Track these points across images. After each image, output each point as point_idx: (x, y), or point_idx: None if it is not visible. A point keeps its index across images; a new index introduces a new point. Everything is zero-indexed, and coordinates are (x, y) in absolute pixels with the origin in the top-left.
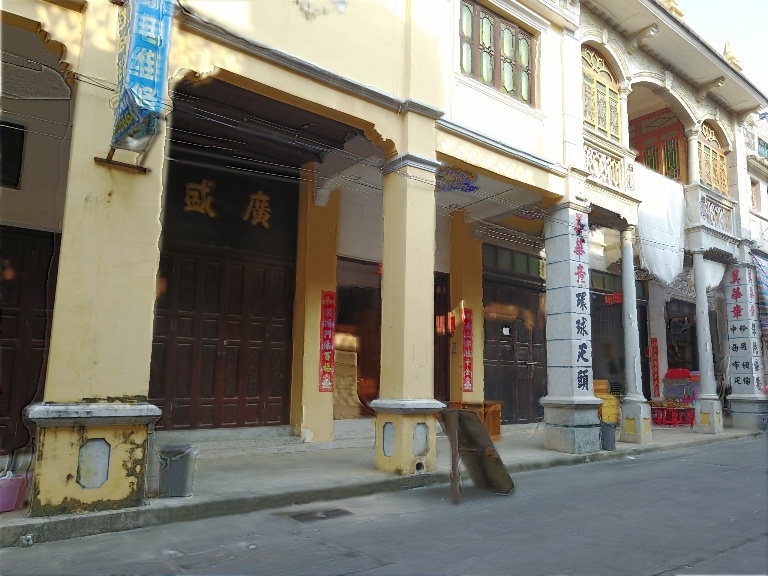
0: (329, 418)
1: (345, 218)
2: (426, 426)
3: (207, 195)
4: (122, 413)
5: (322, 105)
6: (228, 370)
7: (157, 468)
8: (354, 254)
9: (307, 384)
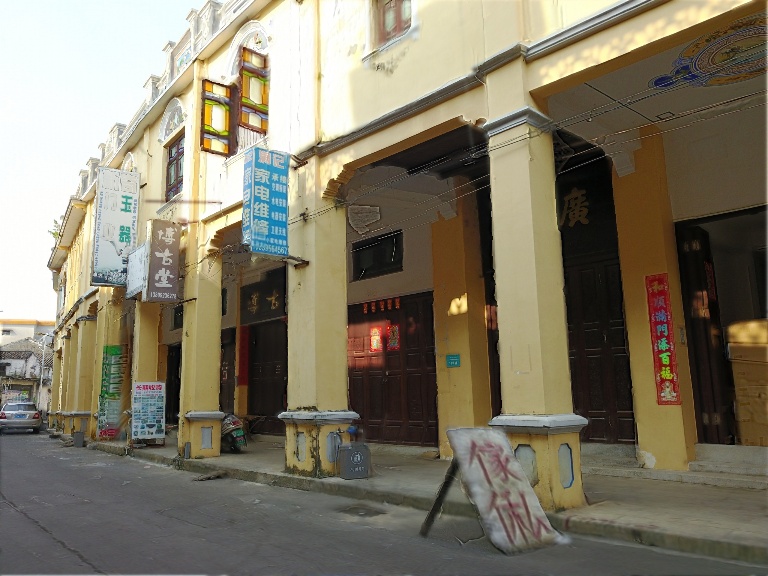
0: (678, 440)
1: (695, 165)
2: (531, 449)
3: None
4: (301, 417)
5: (414, 135)
6: None
7: (335, 456)
8: (722, 207)
9: (639, 395)
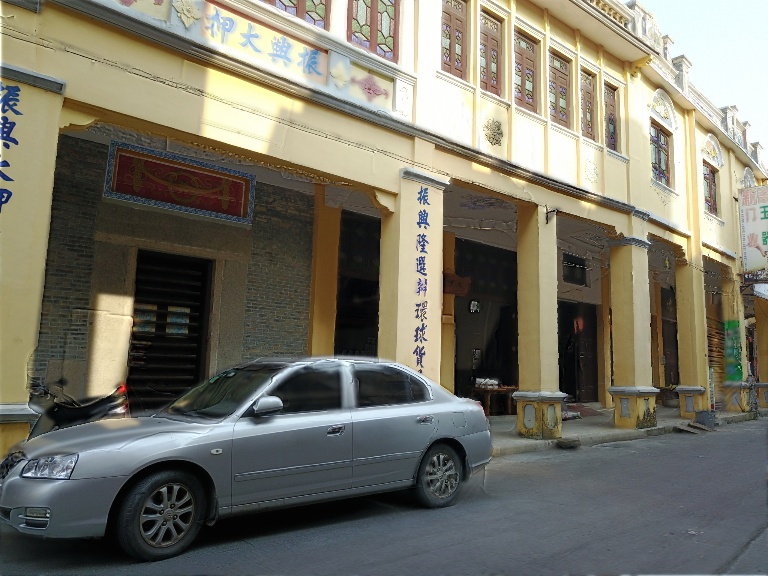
0: None
1: None
2: None
3: None
4: None
5: None
6: None
7: None
8: None
9: None
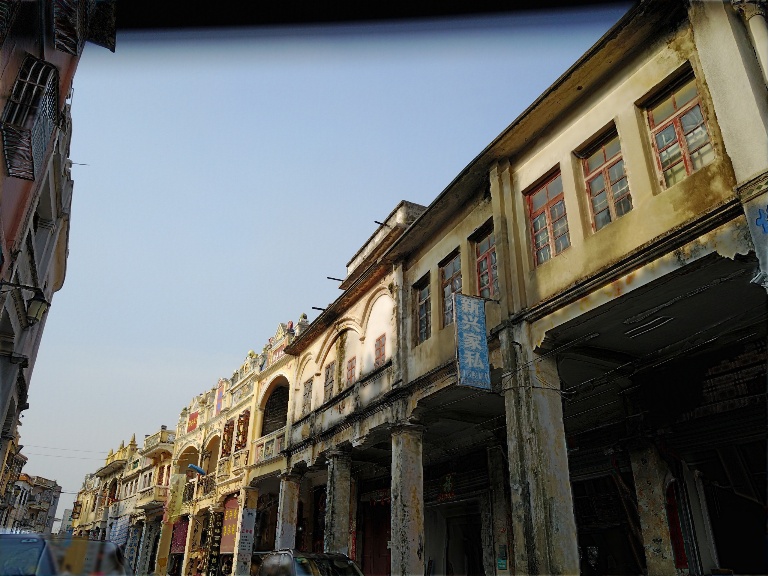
0: None
1: None
2: None
3: None
4: None
5: None
6: None
7: None
8: None
9: None
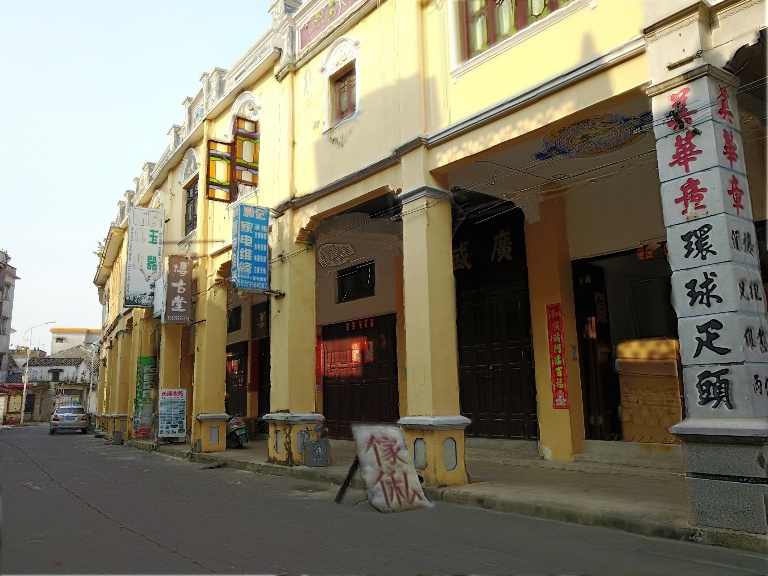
0: (566, 437)
1: (586, 215)
2: (423, 442)
3: (464, 253)
4: None
5: (358, 197)
6: (496, 390)
7: None
8: (604, 250)
9: (541, 401)
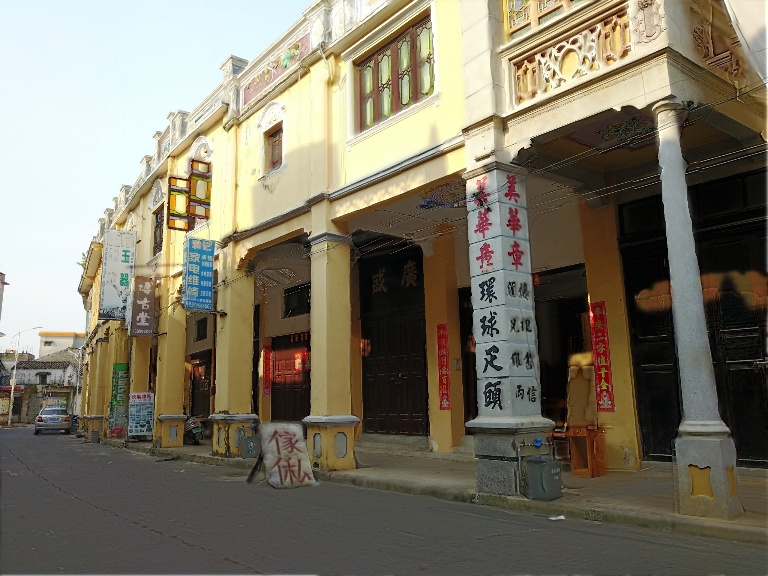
0: (448, 433)
1: None
2: (320, 436)
3: (382, 279)
4: None
5: (282, 236)
6: (404, 394)
7: None
8: None
9: (431, 404)
